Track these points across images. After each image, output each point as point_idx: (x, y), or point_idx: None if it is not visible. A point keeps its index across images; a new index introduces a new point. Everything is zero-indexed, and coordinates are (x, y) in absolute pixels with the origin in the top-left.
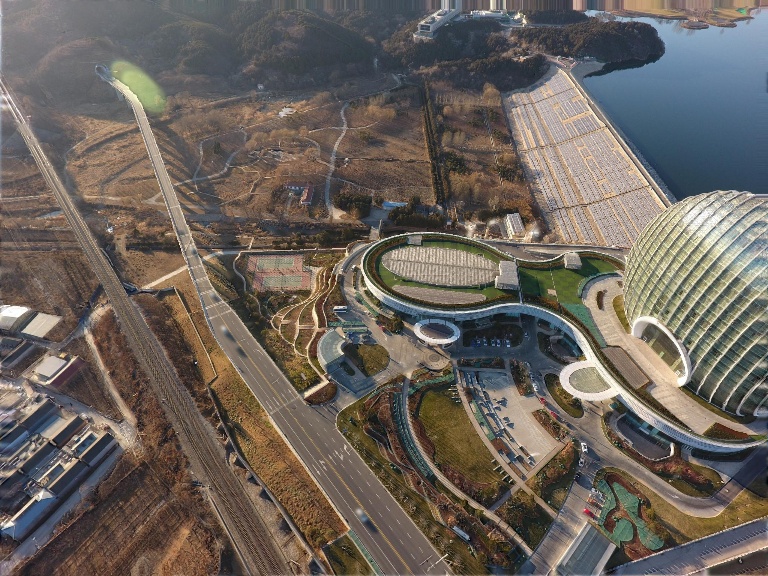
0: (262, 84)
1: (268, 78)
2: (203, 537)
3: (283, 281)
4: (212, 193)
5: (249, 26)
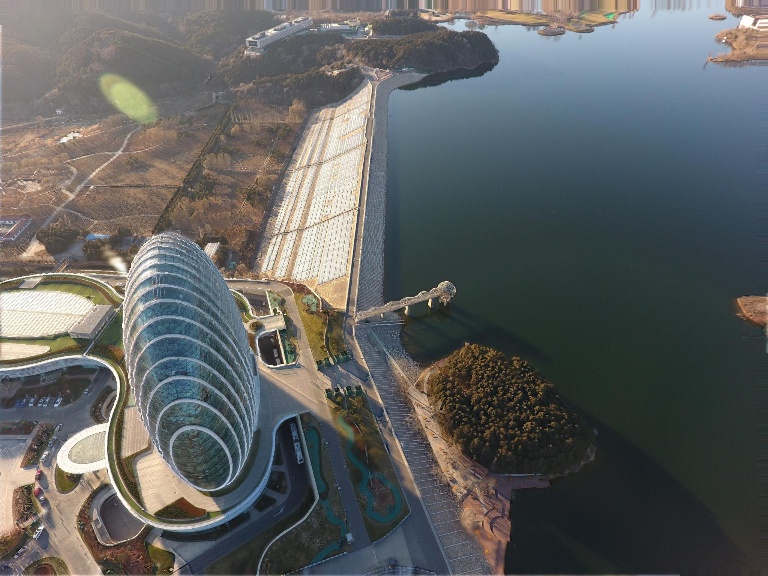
0: (60, 108)
1: (69, 102)
2: None
3: None
4: None
5: (70, 48)
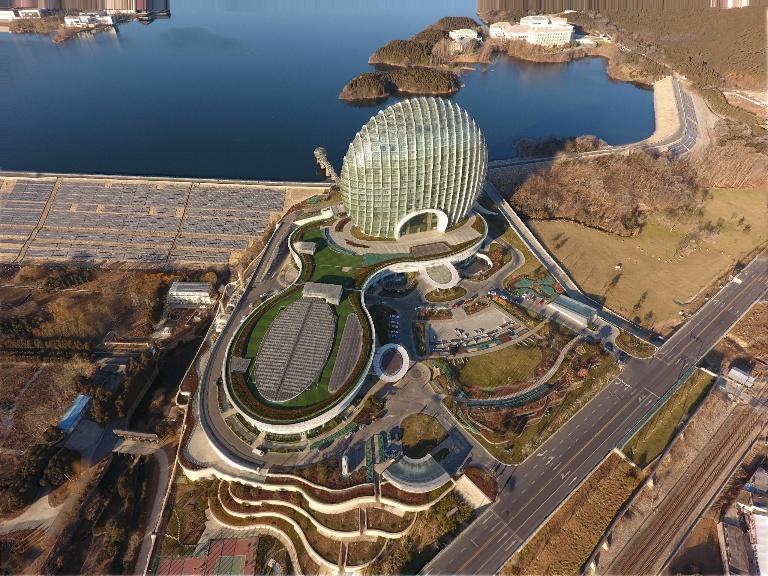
0: None
1: None
2: None
3: None
4: None
5: None
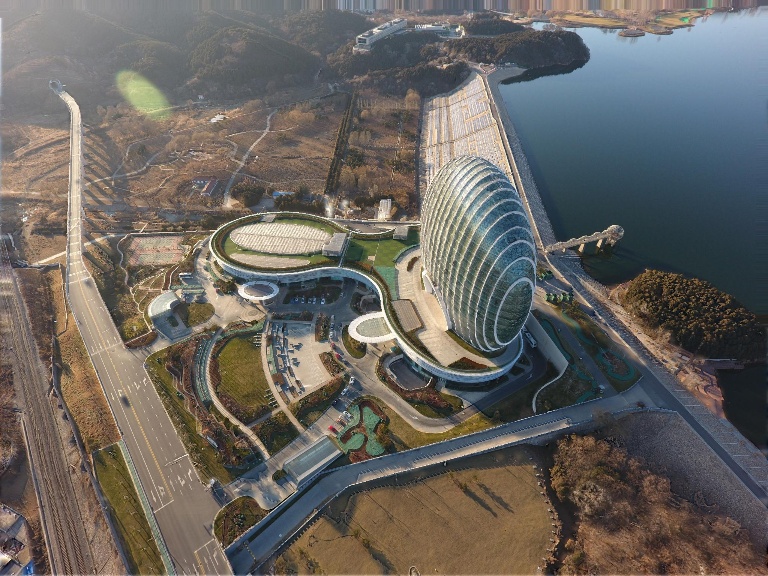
0: (202, 94)
1: (209, 89)
2: (1, 446)
3: (157, 257)
4: (125, 187)
5: (200, 43)
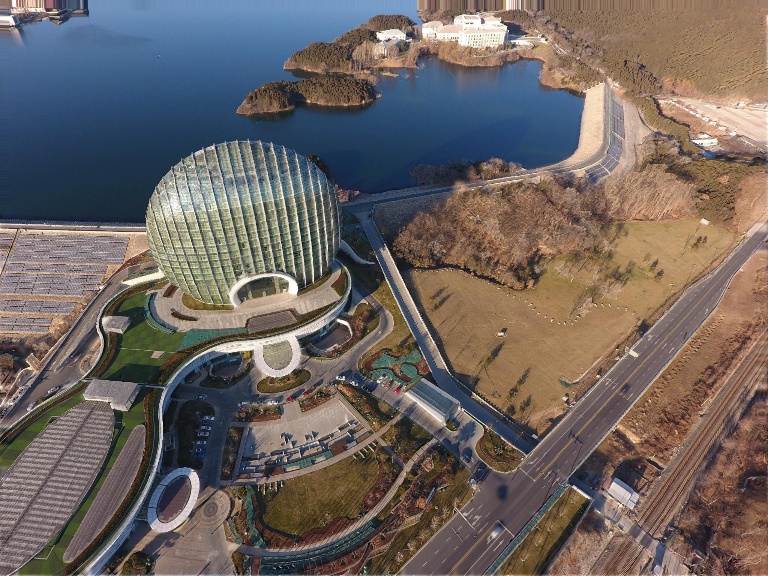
0: None
1: None
2: None
3: None
4: None
5: None
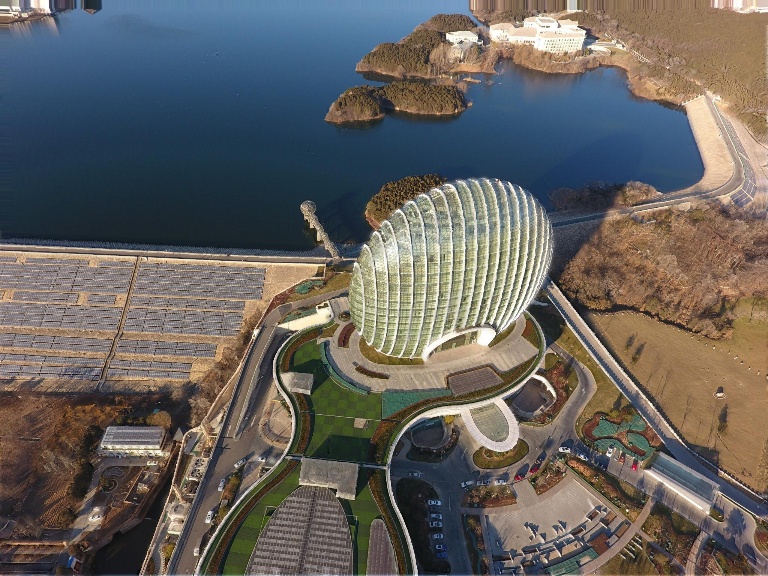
0: None
1: None
2: None
3: None
4: None
5: None
